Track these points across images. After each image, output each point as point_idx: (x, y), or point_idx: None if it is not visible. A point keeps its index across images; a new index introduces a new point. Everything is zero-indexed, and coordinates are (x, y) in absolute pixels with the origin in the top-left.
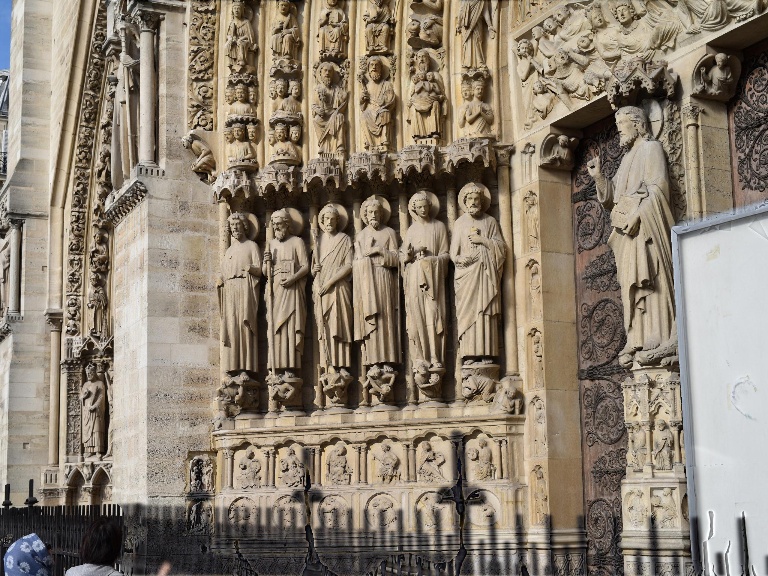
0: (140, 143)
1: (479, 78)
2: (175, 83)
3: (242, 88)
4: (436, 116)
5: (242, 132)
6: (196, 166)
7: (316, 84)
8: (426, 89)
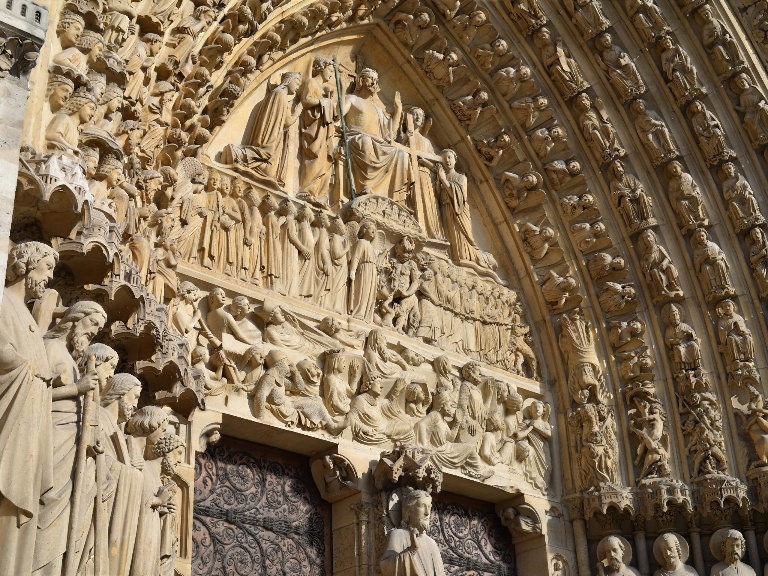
0: None
1: None
2: None
3: None
4: None
5: None
6: None
7: None
8: None
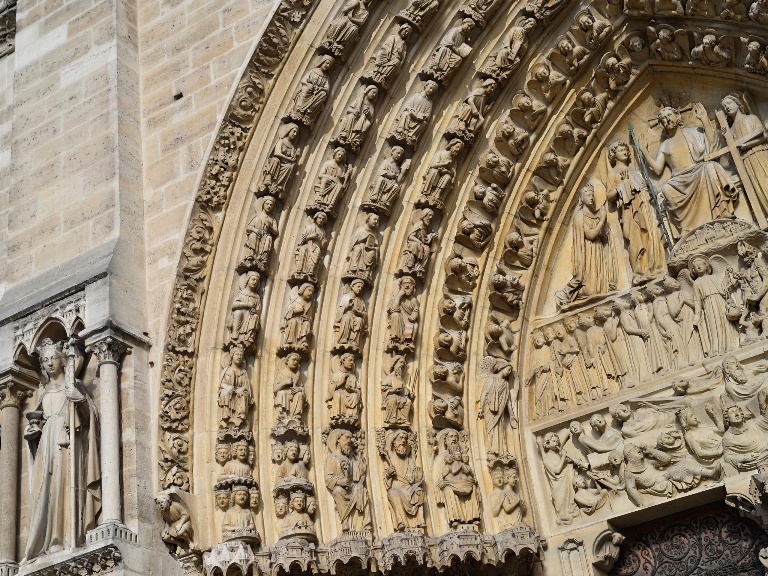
0: (105, 497)
1: (514, 466)
2: (143, 430)
3: (246, 445)
4: (477, 501)
5: (246, 497)
6: (169, 534)
7: (326, 452)
8: (465, 471)
